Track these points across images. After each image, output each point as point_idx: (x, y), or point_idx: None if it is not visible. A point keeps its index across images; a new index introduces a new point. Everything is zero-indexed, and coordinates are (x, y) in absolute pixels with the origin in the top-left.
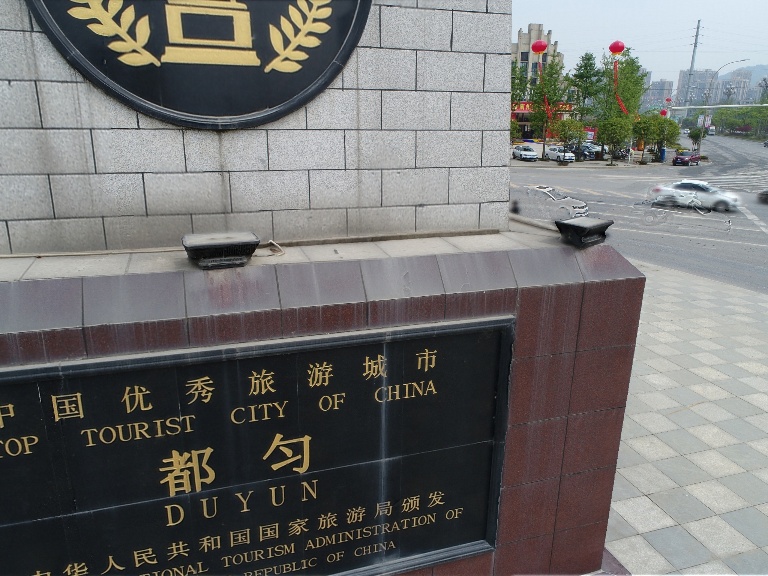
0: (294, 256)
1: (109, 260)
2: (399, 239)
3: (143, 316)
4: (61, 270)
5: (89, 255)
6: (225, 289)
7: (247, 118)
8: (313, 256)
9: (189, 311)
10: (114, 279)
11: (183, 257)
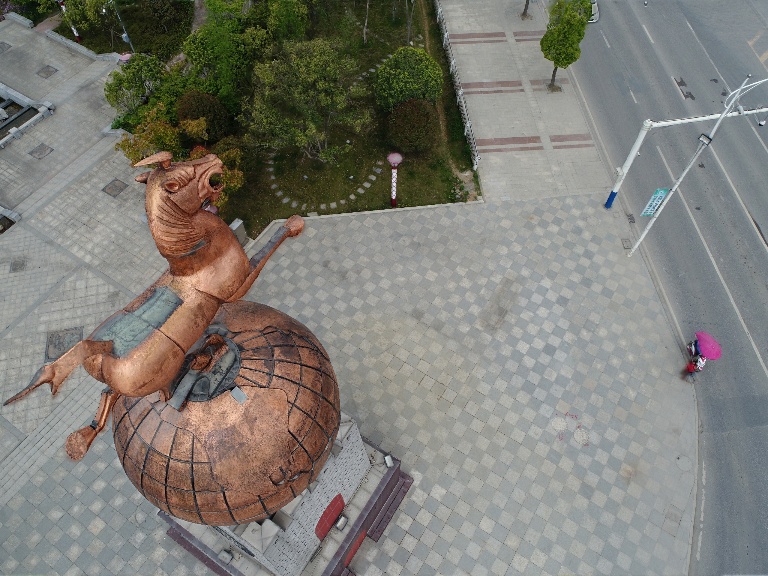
0: (239, 564)
1: (215, 539)
2: (265, 572)
3: (212, 557)
4: (206, 539)
5: (215, 533)
6: (224, 563)
7: (236, 544)
8: (241, 567)
9: (218, 562)
10: (210, 549)
11: (225, 547)
